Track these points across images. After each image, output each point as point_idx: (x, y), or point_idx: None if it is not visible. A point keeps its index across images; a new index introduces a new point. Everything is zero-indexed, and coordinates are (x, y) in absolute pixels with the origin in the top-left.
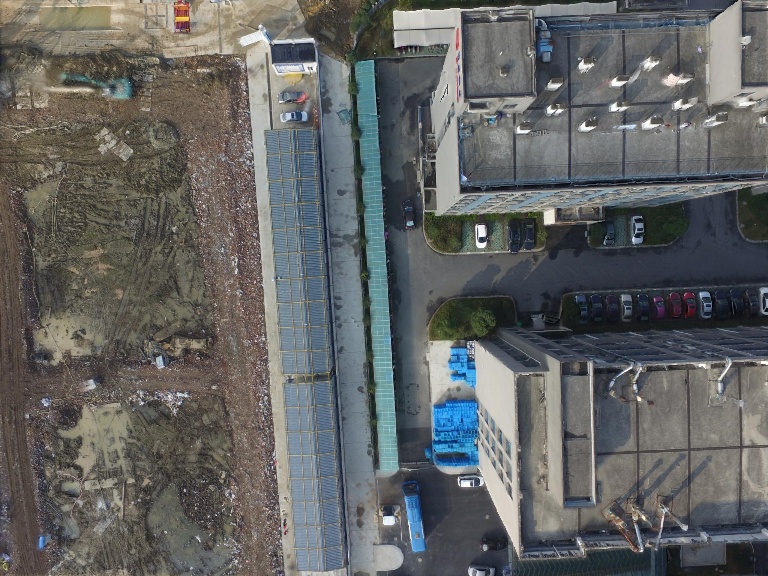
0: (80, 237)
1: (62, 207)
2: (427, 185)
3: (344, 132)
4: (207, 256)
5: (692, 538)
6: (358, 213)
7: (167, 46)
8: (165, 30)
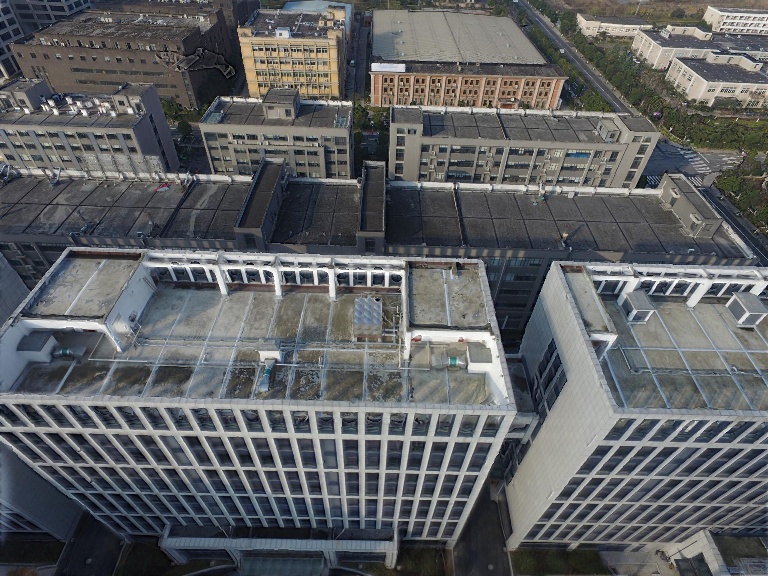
0: None
1: None
2: None
3: None
4: None
5: None
6: None
7: None
8: None
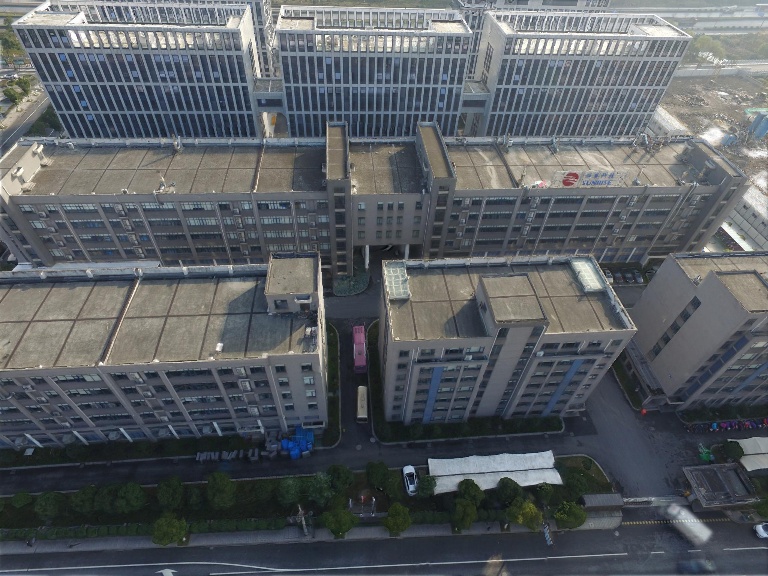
0: None
1: None
2: None
3: None
4: None
5: (618, 140)
6: None
7: None
8: None
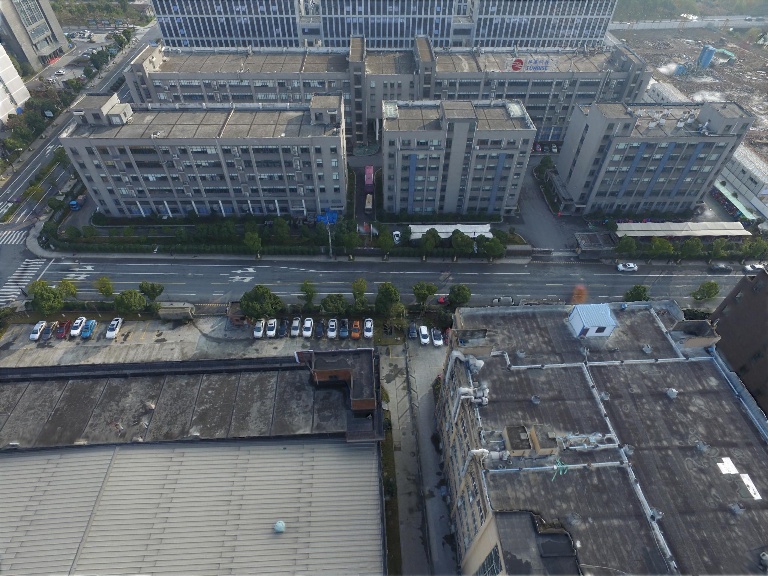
0: None
1: None
2: None
3: None
4: None
5: None
6: None
7: None
8: None
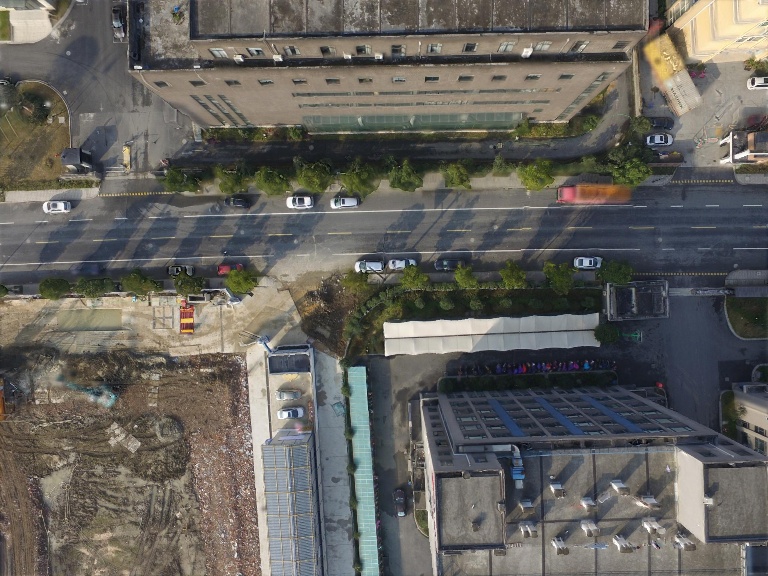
0: (91, 521)
1: (75, 493)
2: (416, 487)
3: (338, 423)
4: (208, 541)
5: None
6: (351, 507)
7: (173, 345)
8: (171, 330)
